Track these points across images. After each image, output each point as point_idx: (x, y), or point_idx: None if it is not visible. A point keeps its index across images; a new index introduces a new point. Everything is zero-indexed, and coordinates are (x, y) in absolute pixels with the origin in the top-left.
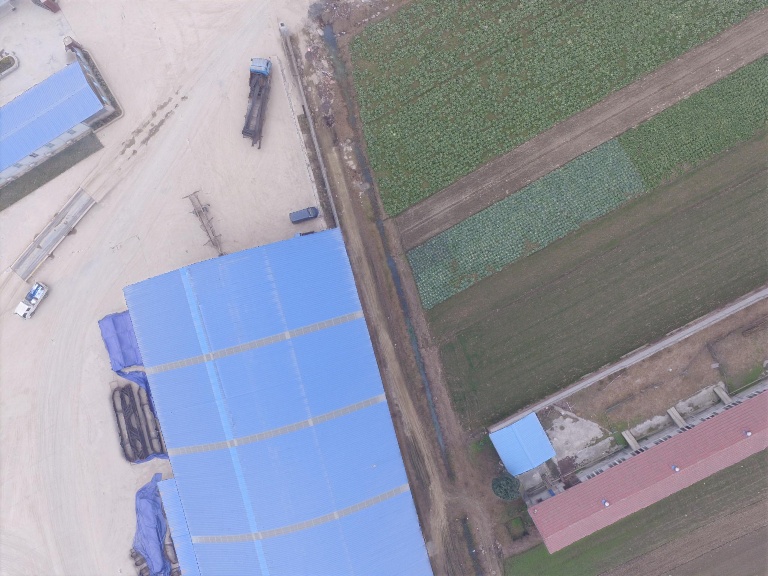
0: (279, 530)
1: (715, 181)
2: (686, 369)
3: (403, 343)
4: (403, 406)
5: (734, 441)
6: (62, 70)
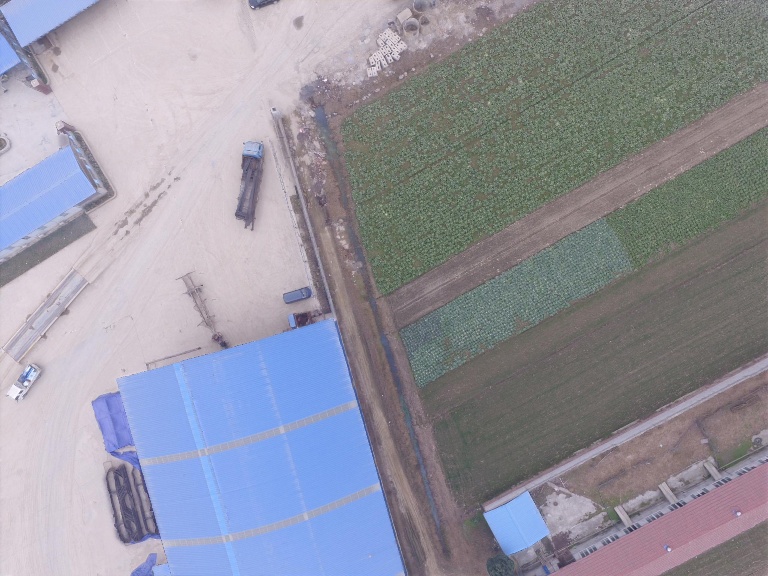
0: None
1: (701, 260)
2: (676, 445)
3: (397, 420)
4: (398, 483)
5: (724, 521)
6: (54, 155)
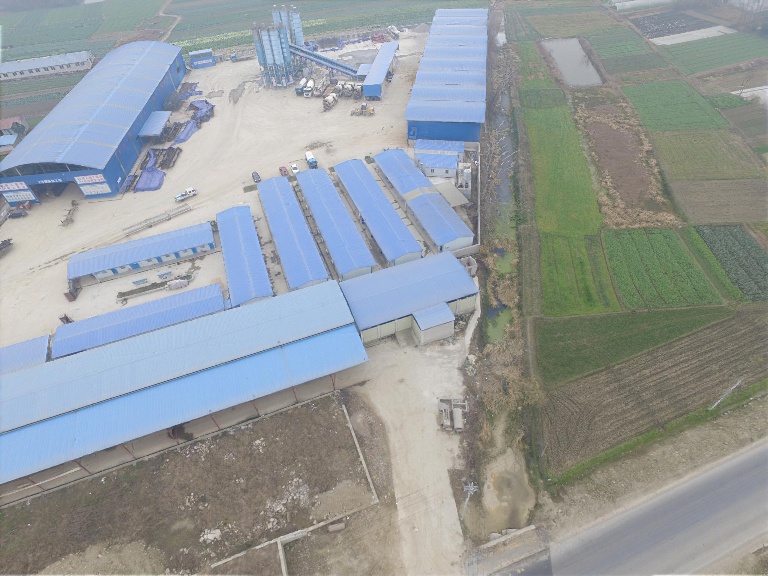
0: None
1: None
2: None
3: None
4: None
5: None
6: (81, 275)
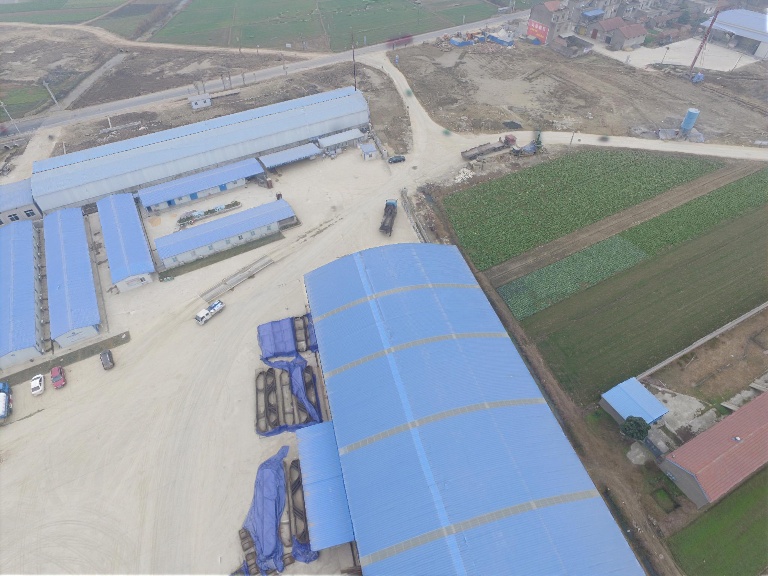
0: (435, 416)
1: (693, 253)
2: (744, 354)
3: None
4: None
5: None
6: (273, 202)
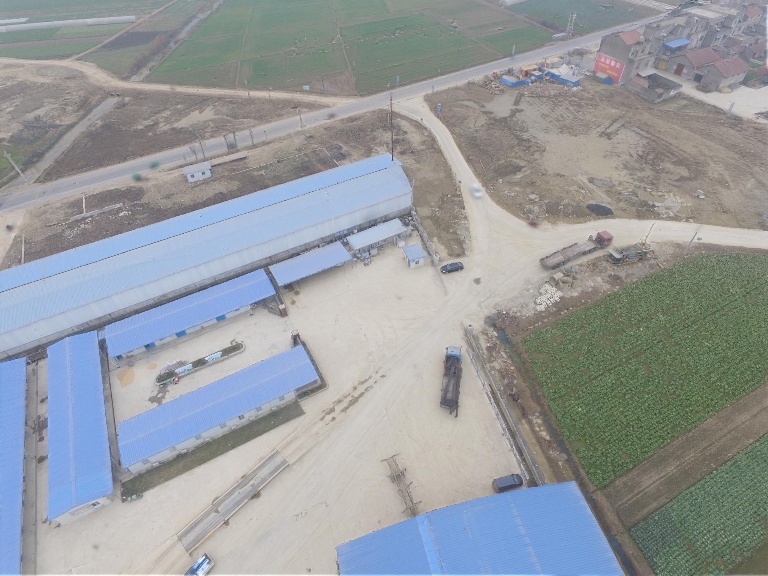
0: None
1: None
2: None
3: None
4: None
5: None
6: (288, 351)
